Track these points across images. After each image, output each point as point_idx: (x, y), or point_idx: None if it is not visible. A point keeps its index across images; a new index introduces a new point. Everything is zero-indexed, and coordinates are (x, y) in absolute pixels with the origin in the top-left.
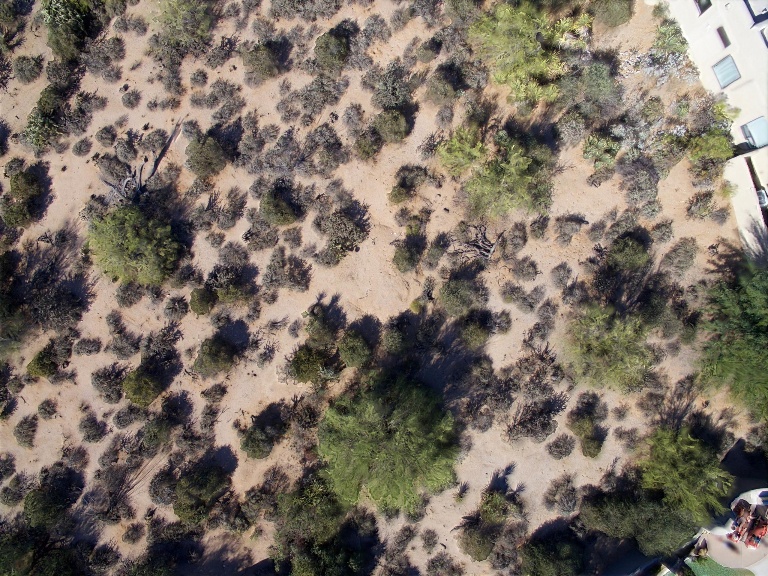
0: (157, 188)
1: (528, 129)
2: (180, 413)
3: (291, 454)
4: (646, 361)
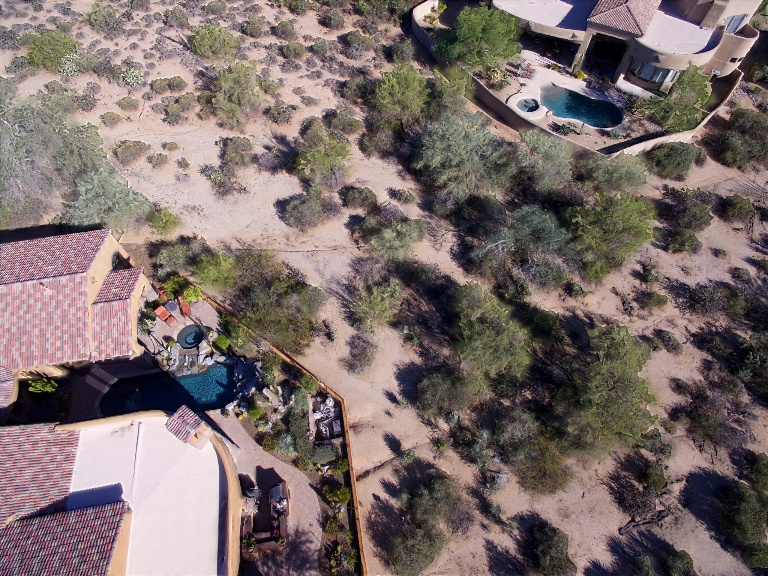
0: (187, 39)
1: None
2: None
3: (347, 19)
4: None
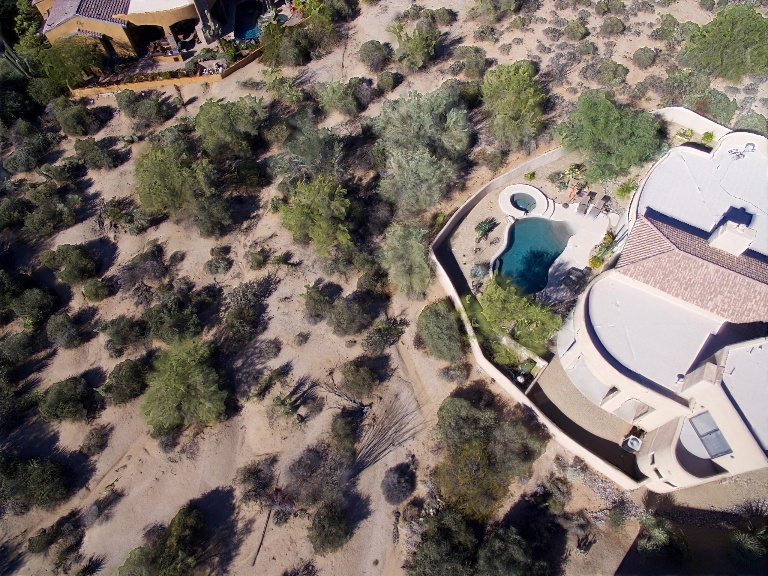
0: None
1: None
2: (594, 46)
3: (661, 70)
4: None
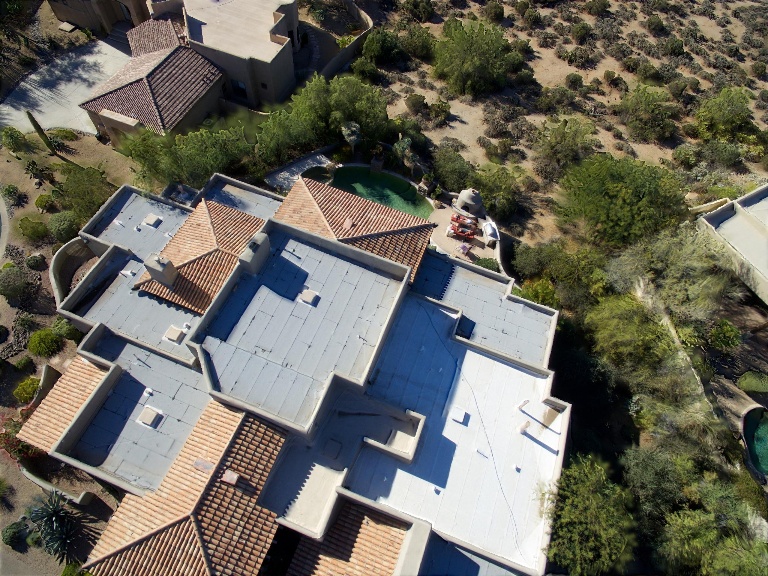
0: None
1: (676, 135)
2: (461, 3)
3: None
4: (559, 181)
